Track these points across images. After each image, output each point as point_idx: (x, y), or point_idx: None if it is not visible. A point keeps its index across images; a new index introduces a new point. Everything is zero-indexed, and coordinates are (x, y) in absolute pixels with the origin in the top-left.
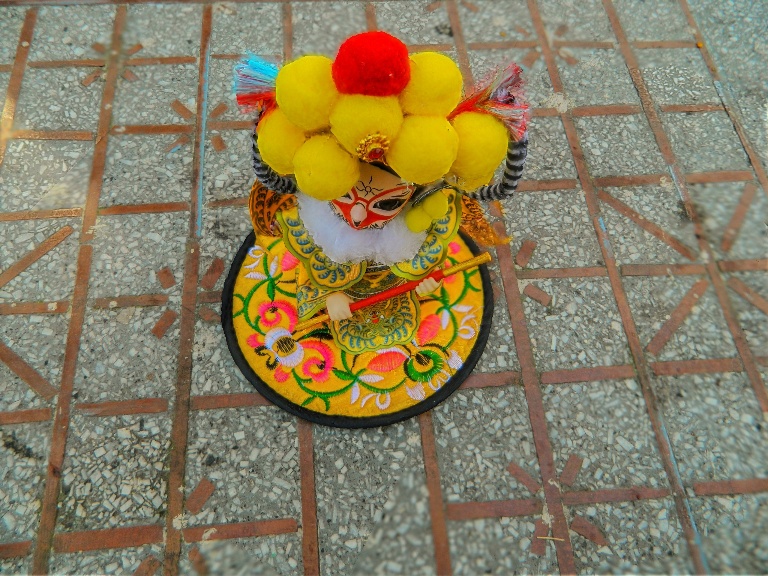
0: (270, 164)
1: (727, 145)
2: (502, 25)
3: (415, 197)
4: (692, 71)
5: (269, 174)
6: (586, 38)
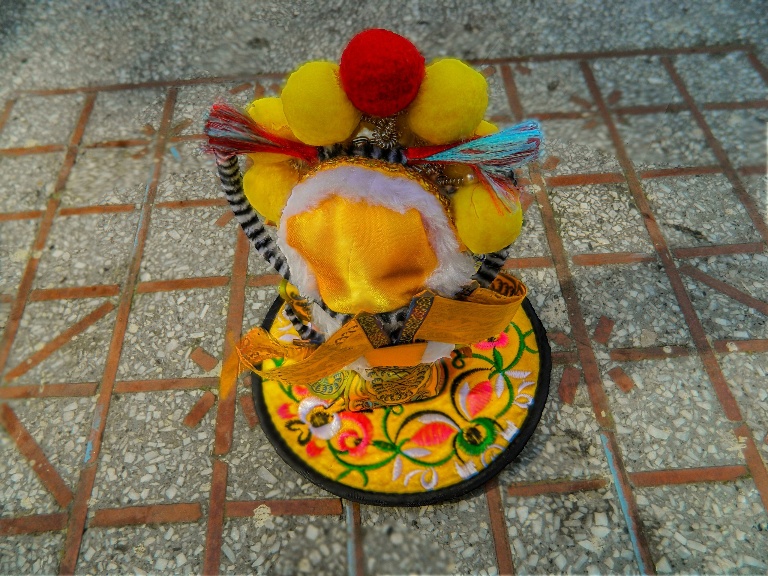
0: None
1: None
2: None
3: None
4: None
5: None
6: None
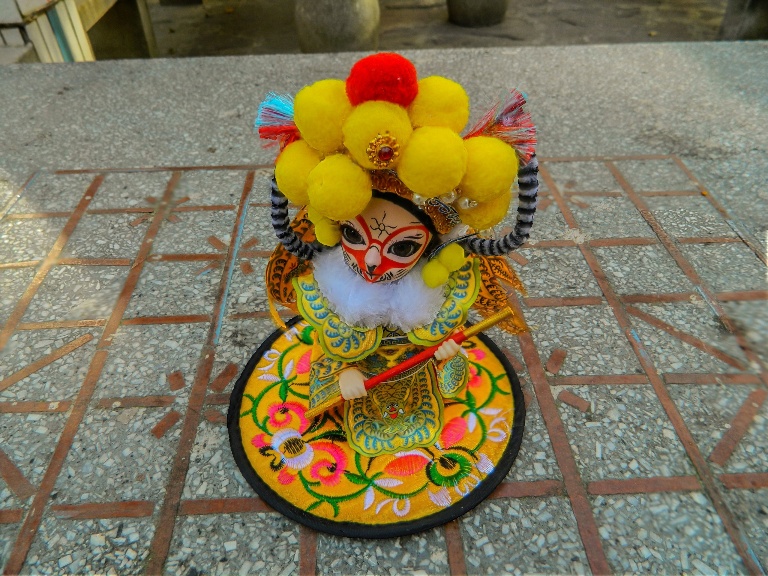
0: (285, 190)
1: (753, 269)
2: (515, 181)
3: (431, 251)
4: (702, 212)
5: (286, 227)
6: (595, 189)
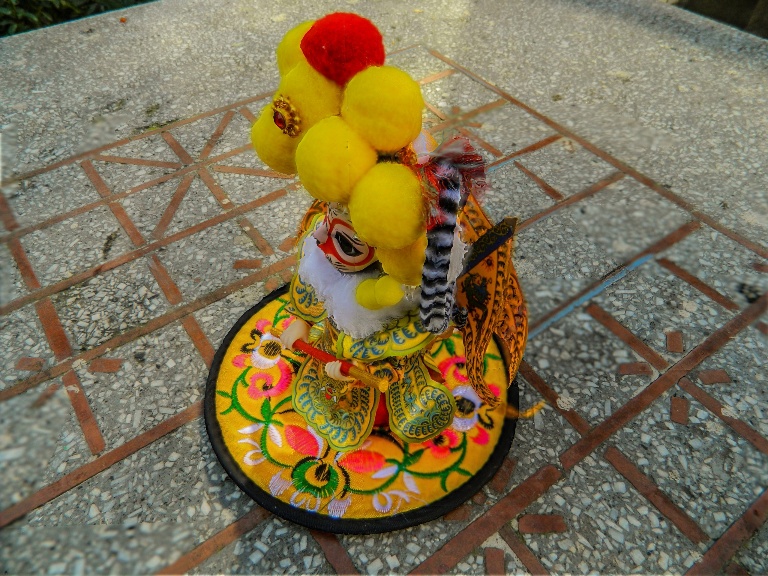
0: None
1: None
2: None
3: None
4: None
5: None
6: None
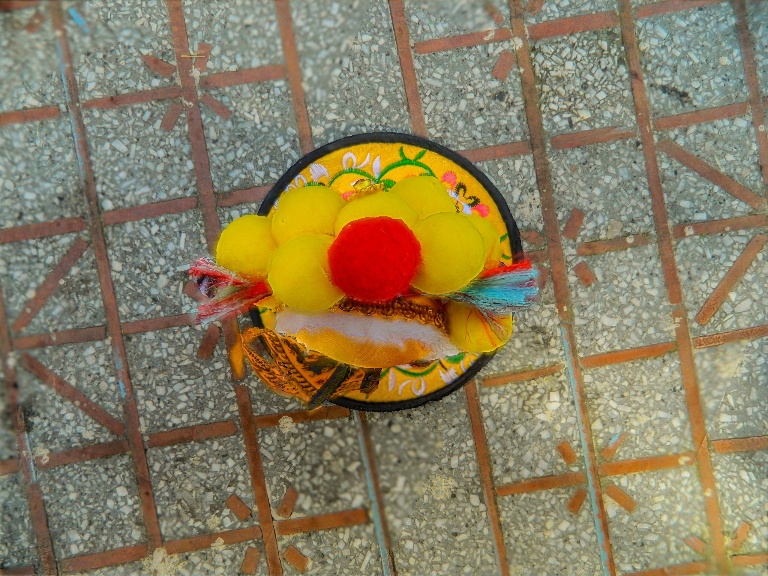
0: None
1: None
2: None
3: None
4: None
5: None
6: None
